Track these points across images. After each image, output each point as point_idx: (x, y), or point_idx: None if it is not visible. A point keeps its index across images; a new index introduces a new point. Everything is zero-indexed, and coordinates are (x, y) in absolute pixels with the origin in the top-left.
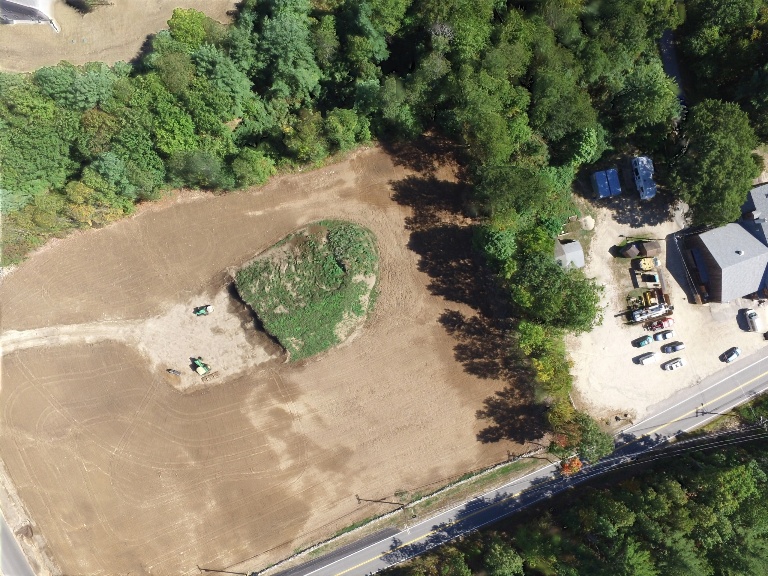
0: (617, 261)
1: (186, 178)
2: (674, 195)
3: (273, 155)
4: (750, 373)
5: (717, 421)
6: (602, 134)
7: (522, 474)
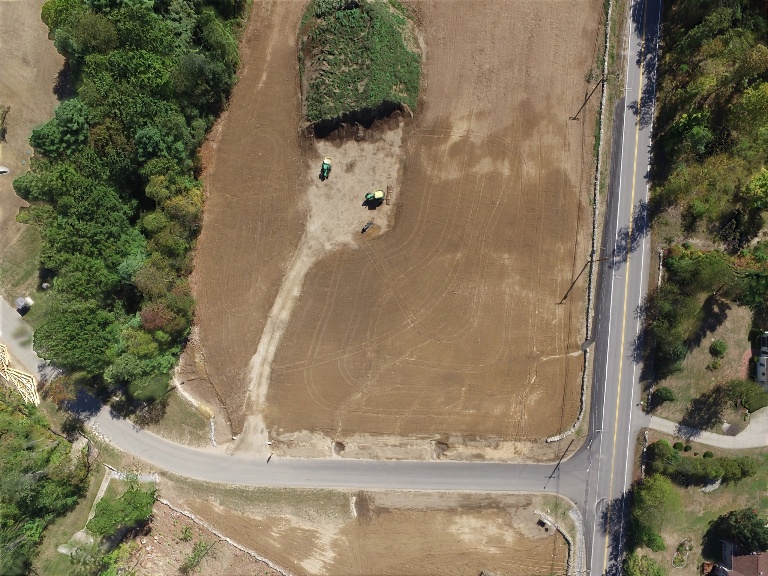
0: None
1: (197, 103)
2: None
3: None
4: None
5: None
6: None
7: None
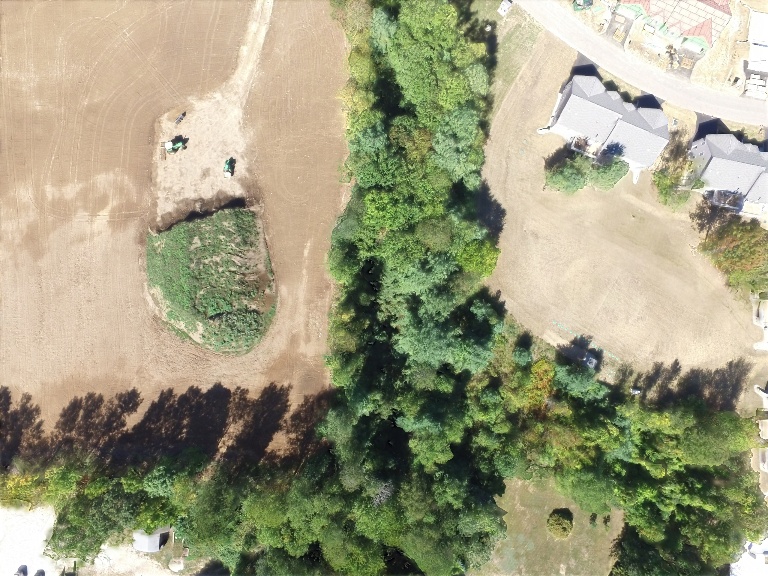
0: None
1: None
2: None
3: None
4: None
5: None
6: None
7: None
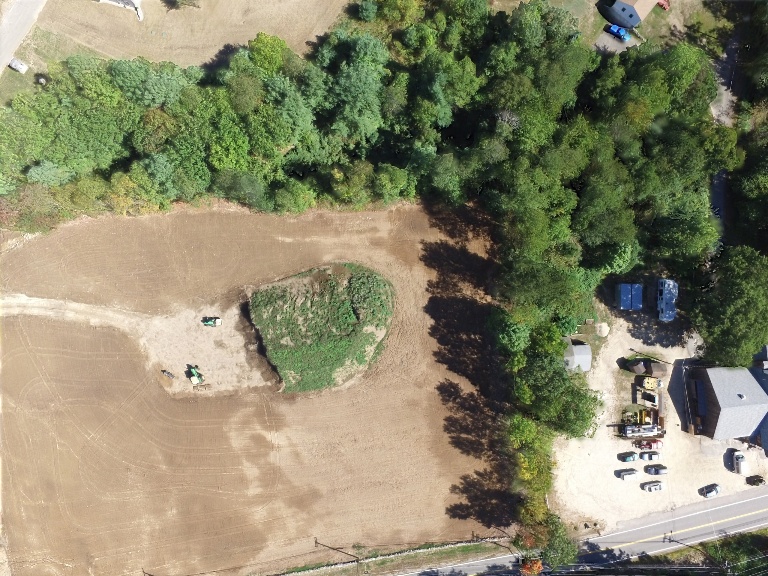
0: (622, 373)
1: (228, 193)
2: (691, 323)
3: (317, 190)
4: (724, 513)
5: (682, 551)
6: (637, 251)
7: (481, 557)
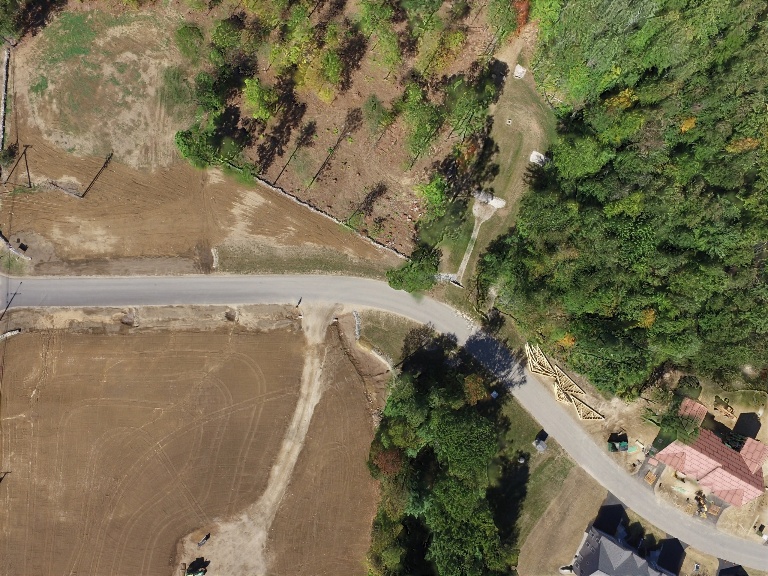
0: None
1: None
2: None
3: None
4: None
5: None
6: None
7: None
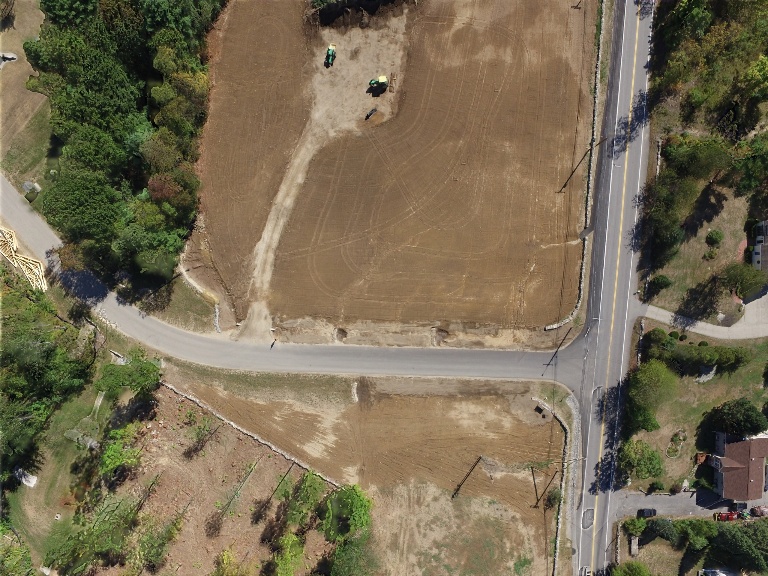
0: None
1: None
2: None
3: None
4: None
5: None
6: None
7: None
